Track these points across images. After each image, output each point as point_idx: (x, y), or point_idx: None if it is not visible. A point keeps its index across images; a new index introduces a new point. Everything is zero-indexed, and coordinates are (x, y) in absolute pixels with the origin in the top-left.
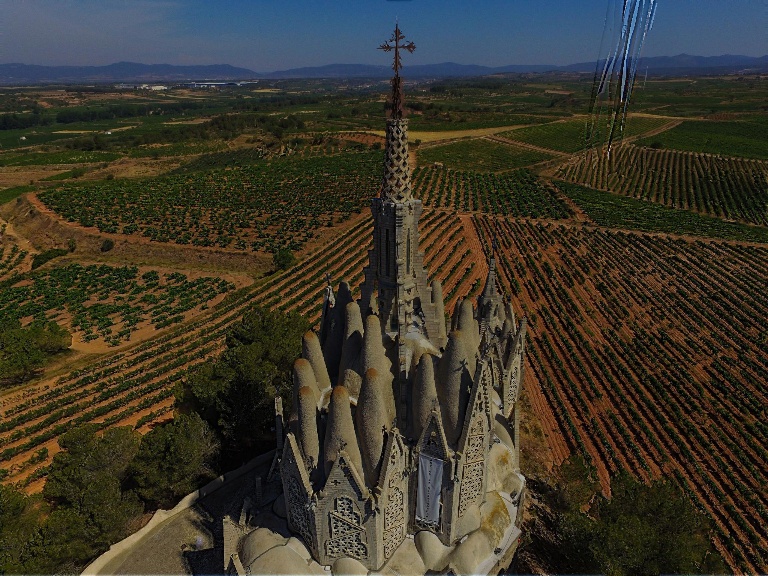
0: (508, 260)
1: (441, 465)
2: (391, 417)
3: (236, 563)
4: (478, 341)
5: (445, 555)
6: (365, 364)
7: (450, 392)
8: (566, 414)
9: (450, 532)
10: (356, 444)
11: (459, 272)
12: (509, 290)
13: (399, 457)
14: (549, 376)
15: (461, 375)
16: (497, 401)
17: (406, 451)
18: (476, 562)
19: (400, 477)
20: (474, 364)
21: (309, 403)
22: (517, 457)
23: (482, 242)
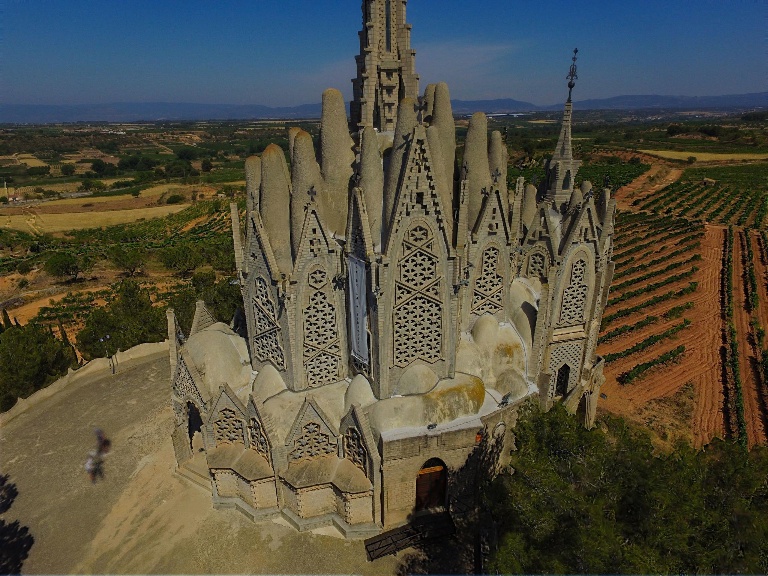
0: (758, 275)
1: (363, 269)
2: (342, 219)
3: (169, 318)
4: (531, 214)
5: (368, 405)
6: (322, 149)
7: (390, 179)
8: (742, 438)
9: (380, 378)
10: (285, 224)
11: (671, 274)
12: (740, 304)
13: (326, 252)
14: (741, 393)
15: (403, 155)
16: (537, 293)
17: (337, 250)
18: (396, 422)
19: (330, 284)
20: (479, 202)
21: (252, 171)
22: (534, 358)
23: (725, 252)
